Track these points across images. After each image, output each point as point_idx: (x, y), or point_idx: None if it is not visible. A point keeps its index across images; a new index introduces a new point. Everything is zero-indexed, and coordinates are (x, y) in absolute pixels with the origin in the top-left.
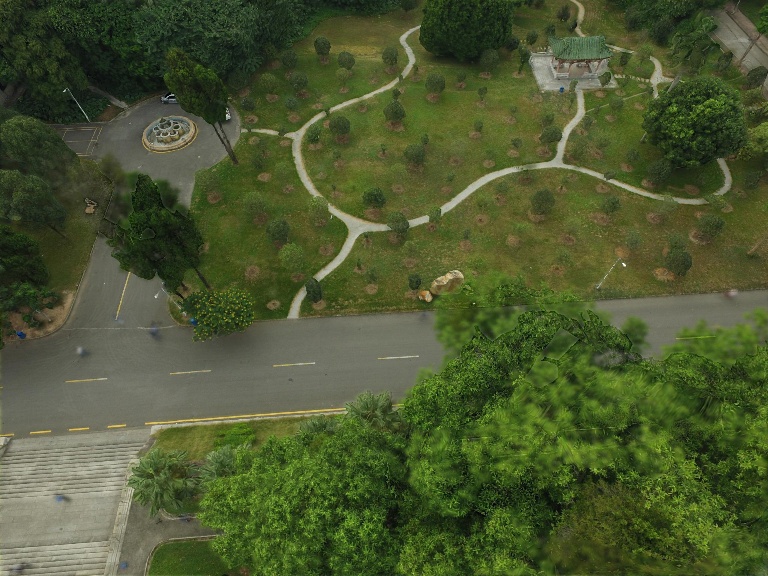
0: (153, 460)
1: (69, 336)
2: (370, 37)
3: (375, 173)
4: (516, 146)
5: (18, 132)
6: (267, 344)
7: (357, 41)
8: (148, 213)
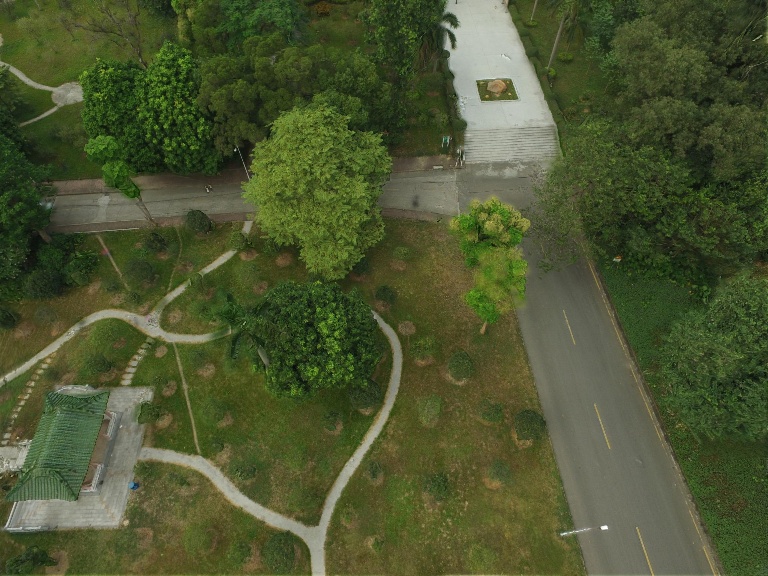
0: None
1: None
2: None
3: None
4: None
5: None
6: None
7: None
8: None
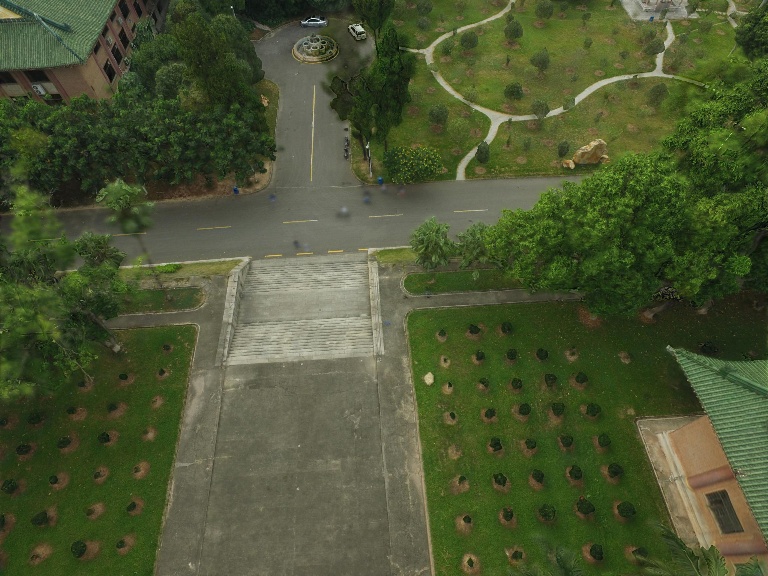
0: (433, 223)
1: (275, 192)
2: None
3: (503, 79)
4: (624, 58)
5: (228, 25)
6: (444, 197)
7: None
8: (391, 61)
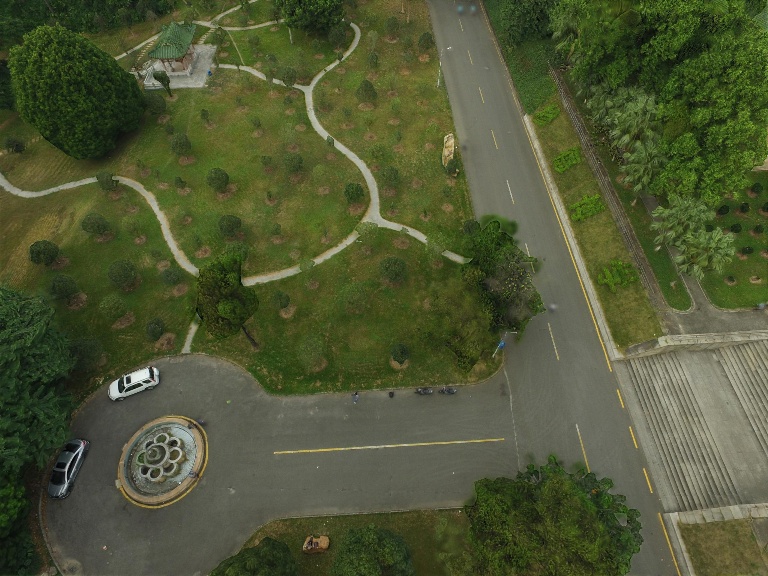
0: None
1: None
2: (5, 229)
3: (299, 207)
4: (291, 102)
5: None
6: None
7: (7, 243)
8: None
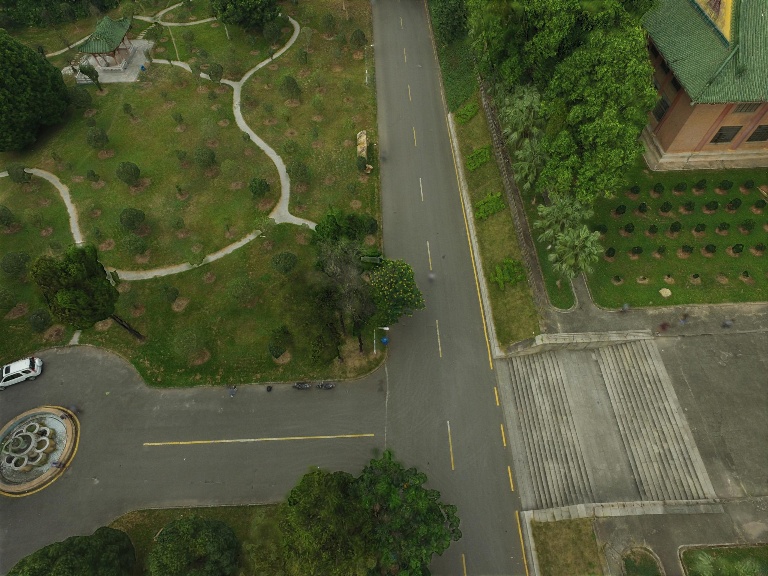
0: None
1: None
2: None
3: (209, 202)
4: (215, 98)
5: (56, 573)
6: None
7: None
8: None
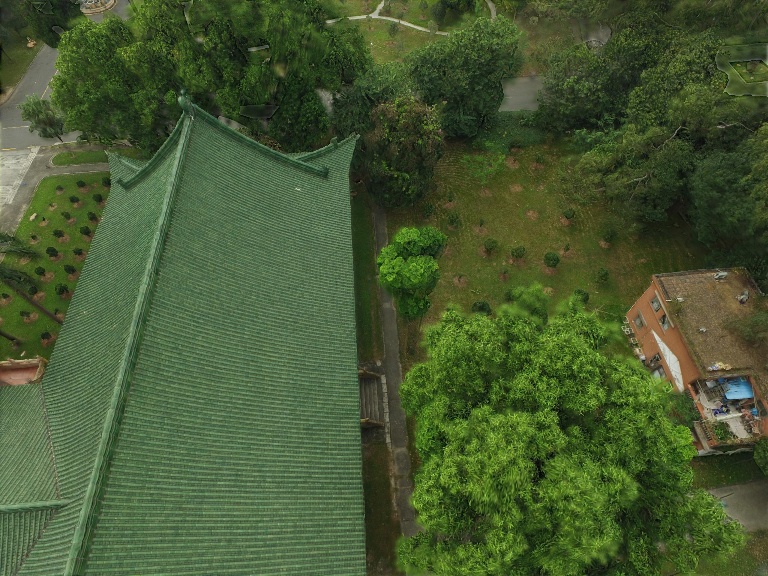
0: (34, 97)
1: (8, 108)
2: None
3: (240, 23)
4: (343, 3)
5: None
6: None
7: None
8: None
